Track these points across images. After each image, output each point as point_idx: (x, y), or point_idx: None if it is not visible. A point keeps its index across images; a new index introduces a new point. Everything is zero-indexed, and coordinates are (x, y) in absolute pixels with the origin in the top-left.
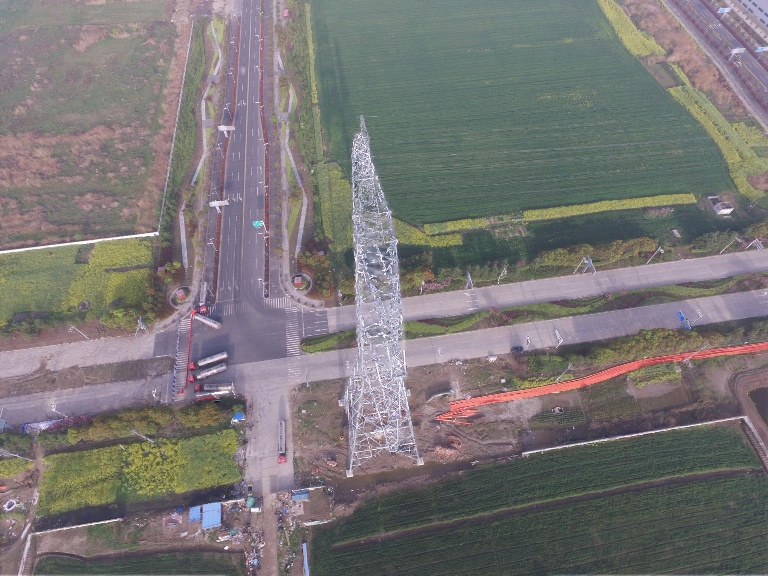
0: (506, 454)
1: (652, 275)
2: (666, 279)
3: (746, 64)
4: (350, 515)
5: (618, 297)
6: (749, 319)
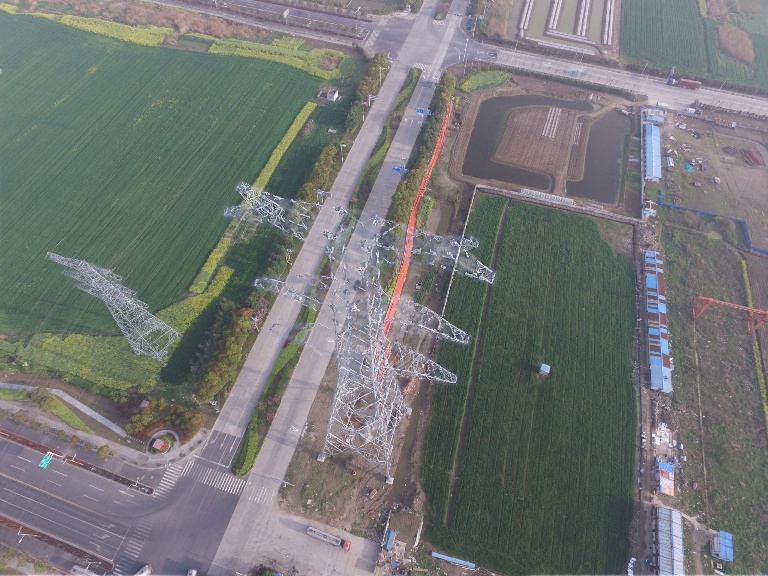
0: (433, 341)
1: (354, 166)
2: (362, 160)
3: (229, 2)
4: (426, 497)
5: (357, 195)
6: (417, 139)
